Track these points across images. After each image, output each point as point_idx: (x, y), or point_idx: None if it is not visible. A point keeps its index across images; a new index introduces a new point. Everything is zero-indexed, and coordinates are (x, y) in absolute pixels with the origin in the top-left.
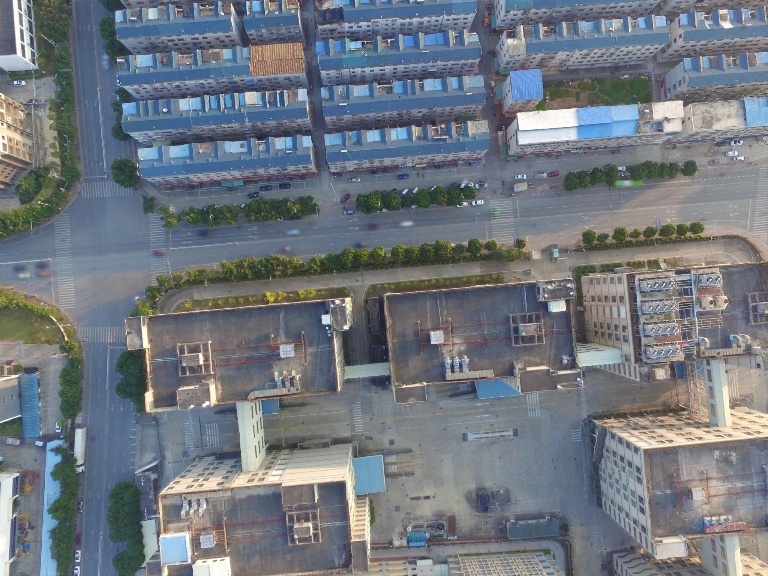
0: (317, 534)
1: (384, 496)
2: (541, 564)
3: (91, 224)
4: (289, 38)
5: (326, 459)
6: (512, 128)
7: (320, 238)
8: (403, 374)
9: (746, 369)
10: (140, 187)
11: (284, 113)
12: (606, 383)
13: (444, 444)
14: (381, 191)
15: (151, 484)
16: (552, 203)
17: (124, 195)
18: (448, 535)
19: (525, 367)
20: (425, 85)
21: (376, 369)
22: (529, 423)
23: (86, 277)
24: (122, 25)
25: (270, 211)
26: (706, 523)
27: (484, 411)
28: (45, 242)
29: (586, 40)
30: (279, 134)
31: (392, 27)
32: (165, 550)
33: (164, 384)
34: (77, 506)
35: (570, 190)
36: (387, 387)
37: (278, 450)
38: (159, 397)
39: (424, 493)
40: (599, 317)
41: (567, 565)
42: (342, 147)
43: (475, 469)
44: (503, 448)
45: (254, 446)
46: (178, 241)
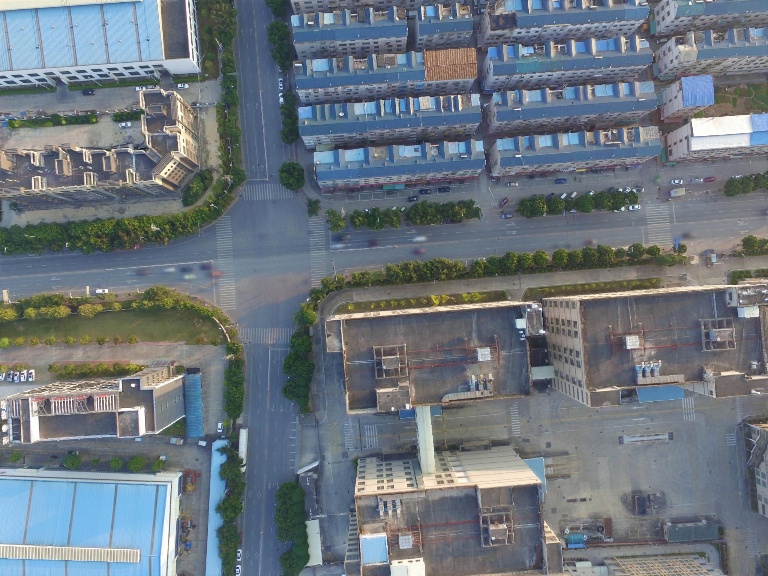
0: (509, 536)
1: None
2: (703, 567)
3: (252, 226)
4: (455, 43)
5: (500, 461)
6: (679, 134)
7: (478, 242)
8: (594, 378)
9: None
10: (300, 190)
11: (458, 118)
12: None
13: (600, 447)
14: (539, 195)
15: (313, 484)
16: (708, 208)
17: (285, 198)
18: (604, 537)
19: (720, 372)
20: (596, 91)
21: (541, 372)
22: (684, 427)
23: (247, 279)
24: (300, 30)
25: (435, 215)
26: None
27: (640, 414)
28: (207, 244)
29: (757, 47)
30: (439, 138)
31: (558, 33)
32: (365, 550)
33: (359, 386)
34: None
35: (731, 196)
36: (544, 390)
37: (438, 452)
38: (354, 399)
39: (580, 495)
40: (767, 322)
41: (722, 568)
42: (515, 152)
43: (631, 472)
44: (659, 451)
45: (433, 448)
46: (338, 244)
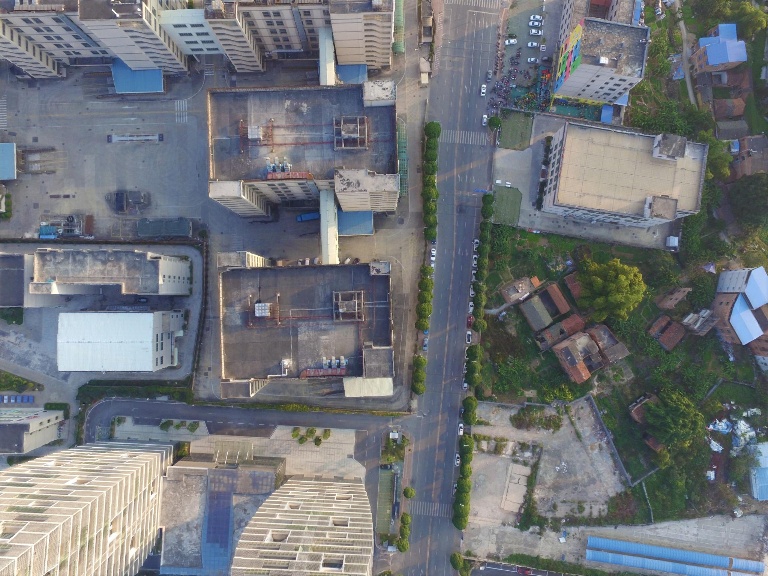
0: None
1: (23, 192)
2: None
3: None
4: None
5: None
6: None
7: None
8: None
9: (401, 89)
10: None
11: None
12: None
13: (88, 144)
14: None
15: None
16: None
17: None
18: (85, 235)
19: None
20: None
21: None
22: (176, 129)
23: None
24: None
25: None
26: (267, 168)
27: (131, 114)
28: None
29: None
30: None
31: None
32: None
33: None
34: None
35: None
36: (34, 84)
37: None
38: None
39: (64, 192)
40: None
41: (202, 271)
42: None
43: (118, 171)
44: (147, 152)
45: None
46: None
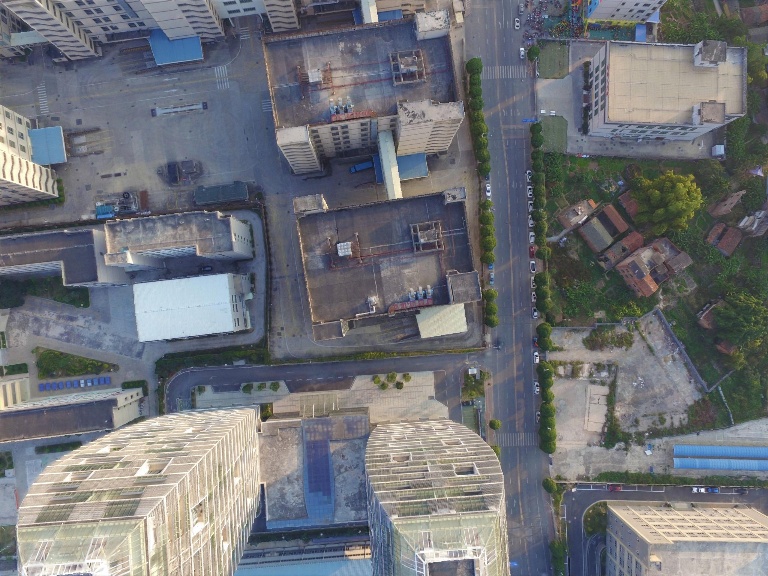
0: None
1: (74, 176)
2: None
3: None
4: None
5: None
6: None
7: None
8: None
9: None
10: None
11: None
12: None
13: (133, 121)
14: None
15: None
16: None
17: None
18: (141, 211)
19: None
20: None
21: None
22: (219, 96)
23: None
24: None
25: None
26: None
27: (172, 86)
28: None
29: None
30: None
31: None
32: None
33: None
34: None
35: None
36: (71, 67)
37: None
38: None
39: (115, 171)
40: None
41: (263, 233)
42: None
43: (166, 144)
44: (193, 122)
45: None
46: None
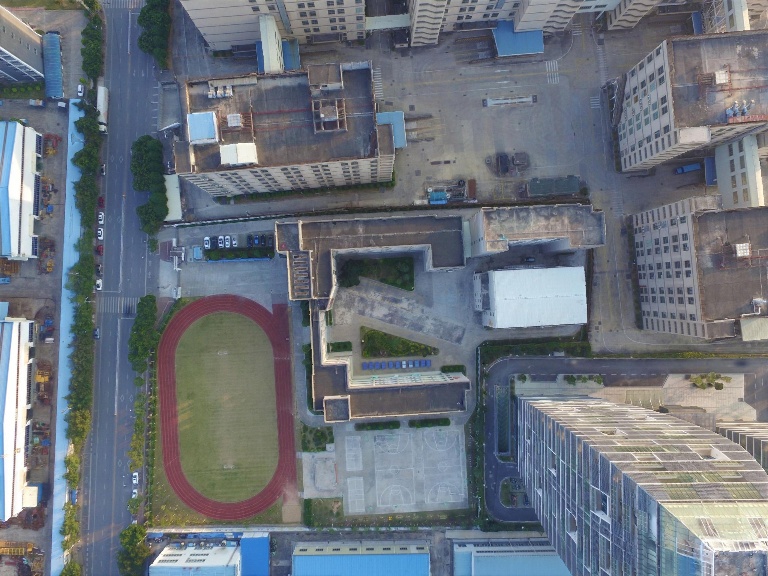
0: (343, 123)
1: (405, 161)
2: None
3: None
4: None
5: None
6: None
7: None
8: None
9: None
10: None
11: None
12: (625, 51)
13: (464, 110)
14: None
15: None
16: None
17: None
18: (468, 199)
19: None
20: None
21: (397, 19)
22: (548, 90)
23: None
24: None
25: None
26: (729, 112)
27: (503, 78)
28: None
29: None
30: None
31: None
32: (193, 126)
33: None
34: (100, 167)
35: None
36: (407, 53)
37: None
38: None
39: (444, 158)
40: None
41: None
42: None
43: (495, 135)
44: (523, 114)
45: (278, 67)
46: None
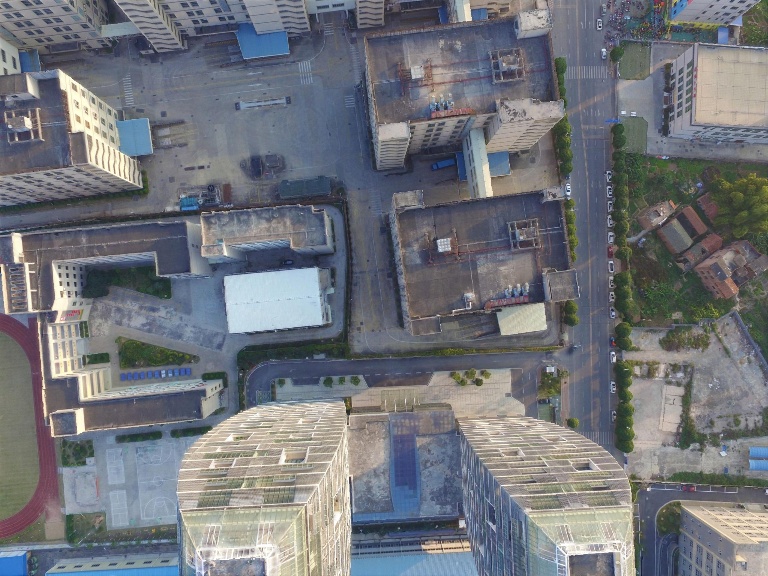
0: (38, 133)
1: (158, 168)
2: None
3: None
4: None
5: None
6: None
7: None
8: None
9: None
10: None
11: None
12: None
13: (217, 114)
14: None
15: None
16: None
17: None
18: (224, 204)
19: None
20: None
21: (133, 26)
22: (302, 91)
23: None
24: None
25: None
26: (431, 107)
27: (256, 80)
28: None
29: None
30: None
31: None
32: None
33: None
34: None
35: None
36: (157, 59)
37: None
38: None
39: (198, 163)
40: None
41: (345, 228)
42: None
43: (249, 138)
44: (277, 116)
45: None
46: None
